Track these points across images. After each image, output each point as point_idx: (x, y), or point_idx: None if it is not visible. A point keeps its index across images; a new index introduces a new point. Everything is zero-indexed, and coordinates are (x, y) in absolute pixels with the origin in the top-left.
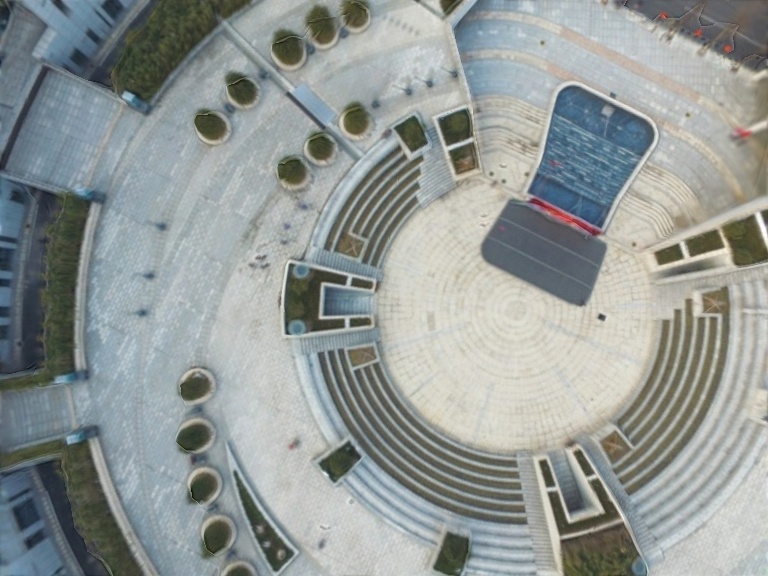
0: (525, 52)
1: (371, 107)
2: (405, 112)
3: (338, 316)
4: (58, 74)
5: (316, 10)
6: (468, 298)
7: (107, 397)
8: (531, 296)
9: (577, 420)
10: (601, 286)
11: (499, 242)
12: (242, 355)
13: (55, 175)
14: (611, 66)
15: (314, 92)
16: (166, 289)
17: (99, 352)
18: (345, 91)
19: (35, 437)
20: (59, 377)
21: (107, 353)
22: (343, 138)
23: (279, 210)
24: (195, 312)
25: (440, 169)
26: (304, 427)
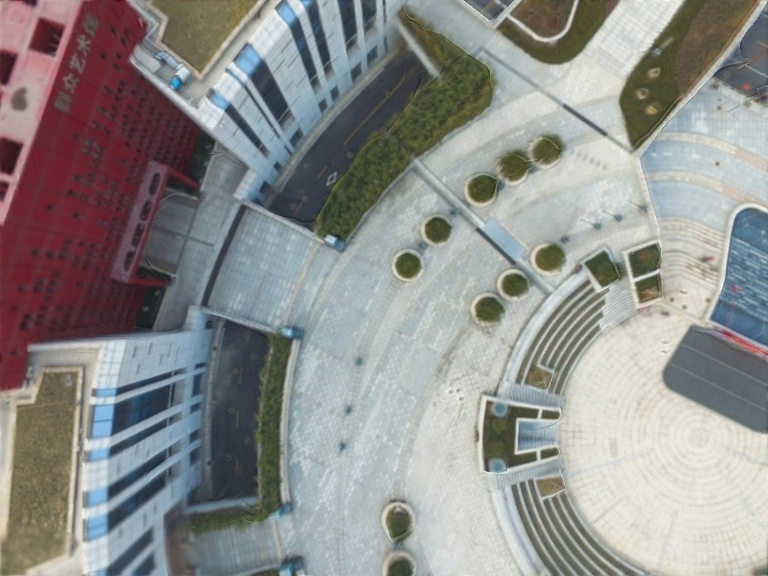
0: (700, 173)
1: (561, 242)
2: (594, 246)
3: (530, 449)
4: (257, 213)
5: (504, 146)
6: (650, 425)
7: (310, 528)
8: (714, 423)
9: (763, 549)
10: None
11: (682, 369)
12: (438, 488)
13: (255, 311)
14: None
15: (503, 227)
16: (364, 423)
17: (301, 484)
18: (534, 226)
19: (245, 568)
20: (272, 514)
21: (309, 485)
22: (534, 274)
23: (471, 344)
24: (392, 445)
25: (623, 298)
26: (501, 561)
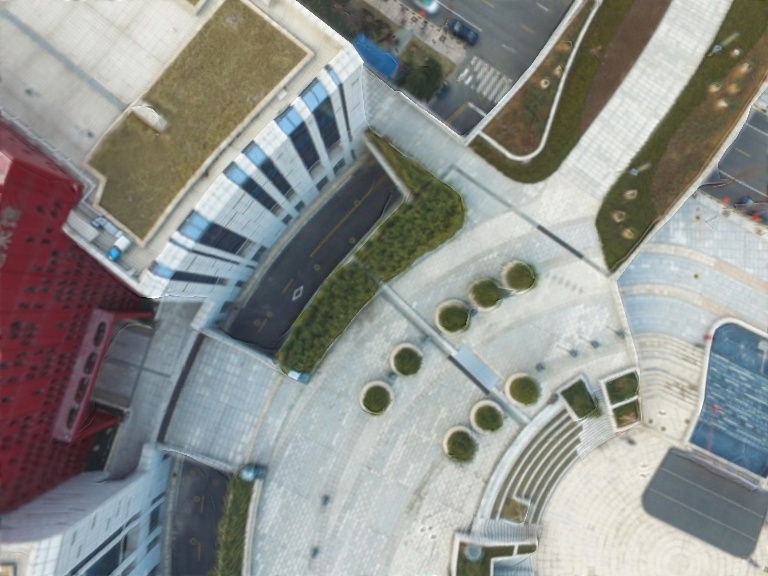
0: (679, 286)
1: (536, 371)
2: (570, 374)
3: None
4: (216, 342)
5: (477, 269)
6: (629, 552)
7: None
8: (694, 549)
9: None
10: (766, 537)
11: (661, 494)
12: None
13: (215, 446)
14: (767, 299)
15: (476, 354)
16: (331, 565)
17: None
18: (508, 353)
19: None
20: None
21: None
22: (509, 405)
23: (444, 479)
24: None
25: (601, 423)
26: None
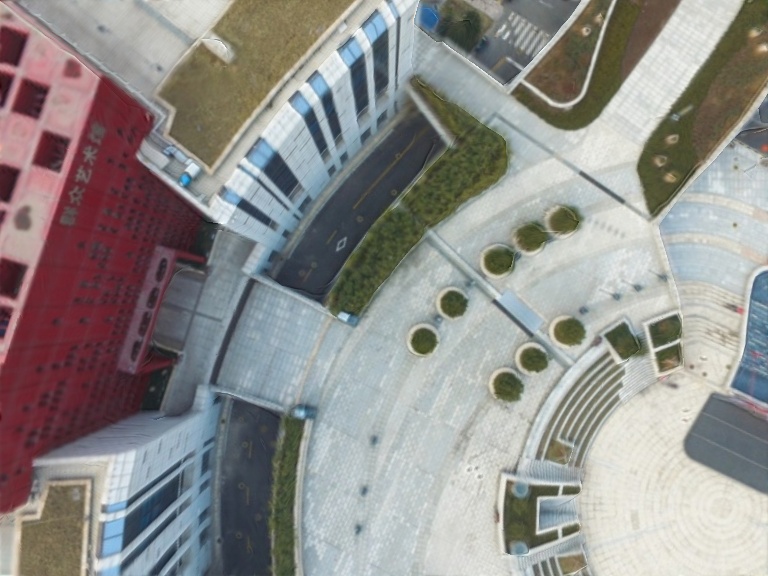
0: (718, 235)
1: (580, 314)
2: (613, 317)
3: (552, 527)
4: (266, 287)
5: (520, 215)
6: (672, 496)
7: None
8: (737, 493)
9: None
10: None
11: (703, 439)
12: (458, 570)
13: (266, 388)
14: None
15: (520, 298)
16: (380, 503)
17: (316, 569)
18: (551, 297)
19: None
20: None
21: (324, 570)
22: (553, 347)
23: (489, 420)
24: (409, 526)
25: (643, 367)
26: None
